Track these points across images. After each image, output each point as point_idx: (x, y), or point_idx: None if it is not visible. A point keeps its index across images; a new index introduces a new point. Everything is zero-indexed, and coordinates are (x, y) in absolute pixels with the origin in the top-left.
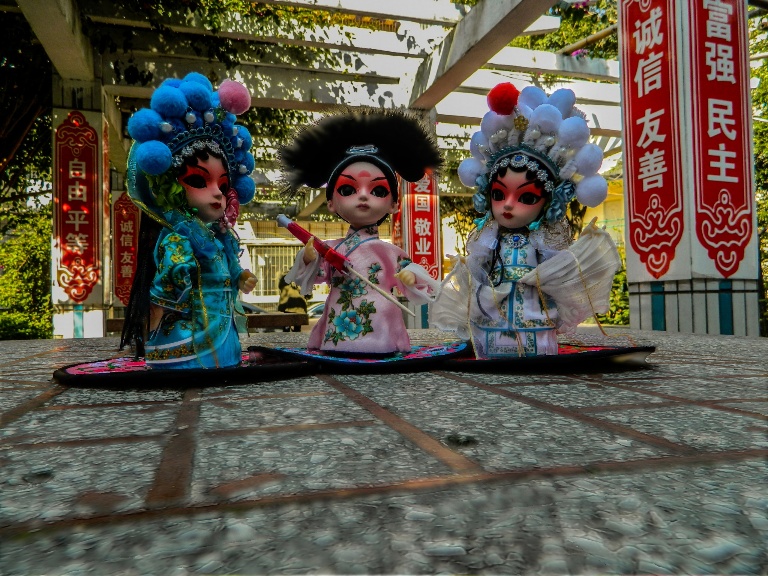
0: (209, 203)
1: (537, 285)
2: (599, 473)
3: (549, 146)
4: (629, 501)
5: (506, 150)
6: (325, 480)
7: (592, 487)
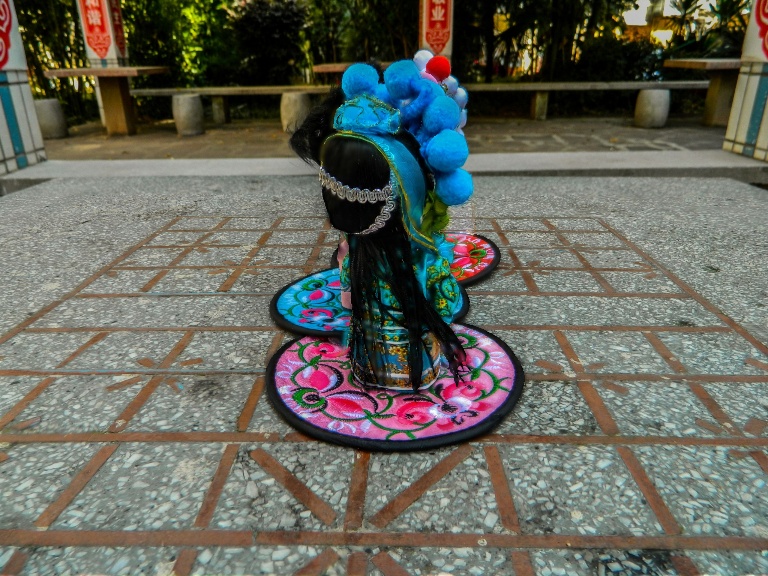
0: None
1: None
2: None
3: None
4: None
5: None
6: (749, 352)
7: None
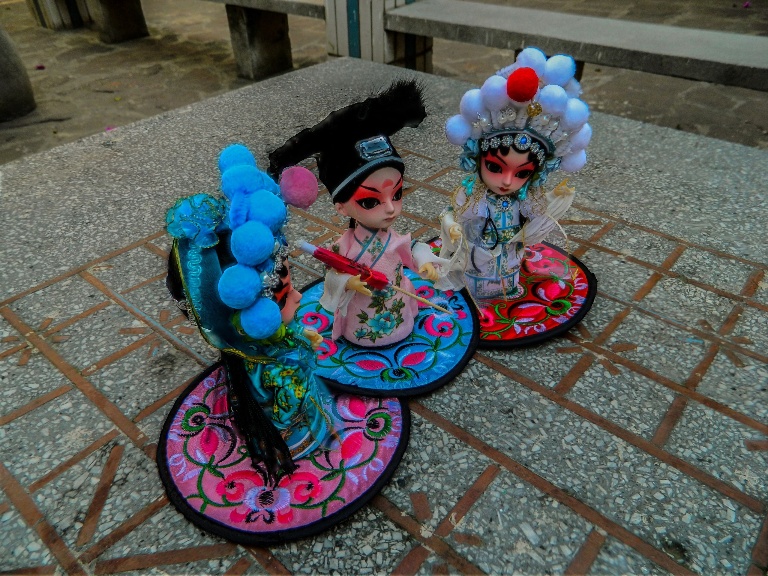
0: (294, 312)
1: None
2: (763, 567)
3: (553, 130)
4: None
5: (511, 129)
6: None
7: None
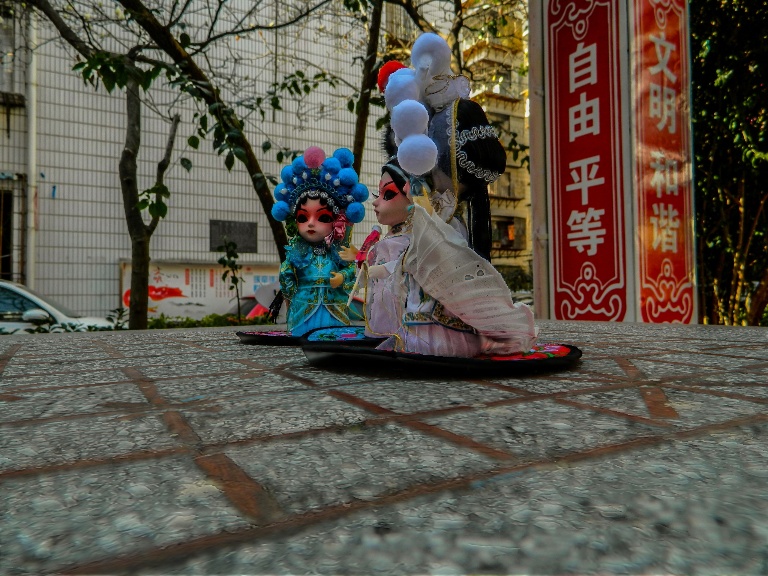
0: (306, 231)
1: None
2: None
3: None
4: None
5: None
6: None
7: None
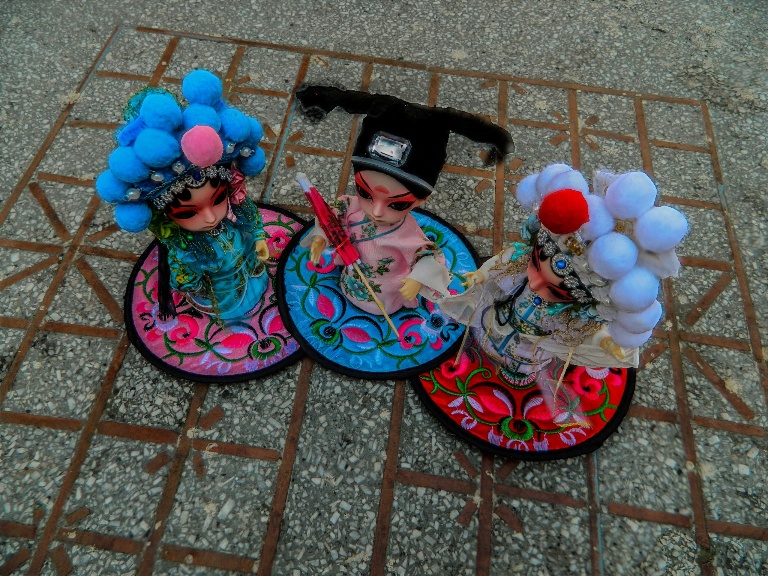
0: (203, 227)
1: None
2: None
3: (596, 285)
4: None
5: None
6: None
7: None
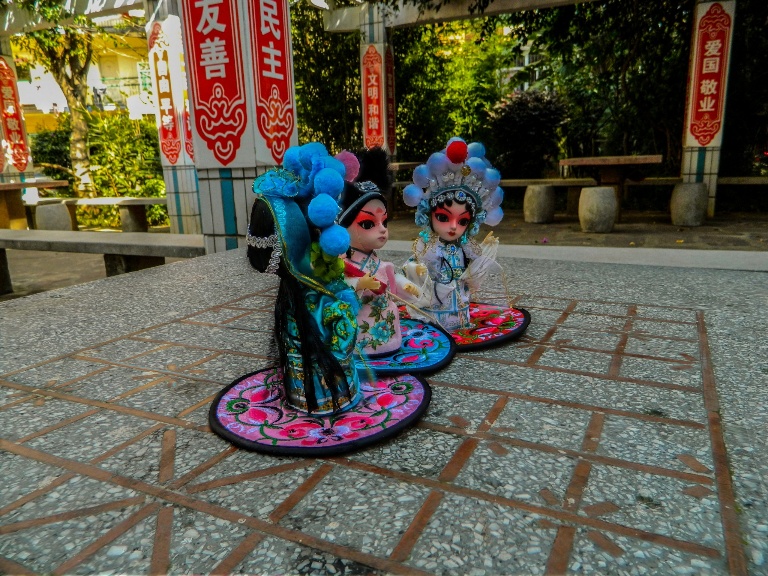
0: None
1: (466, 279)
2: None
3: (479, 187)
4: (751, 420)
5: (451, 187)
6: None
7: (732, 418)
